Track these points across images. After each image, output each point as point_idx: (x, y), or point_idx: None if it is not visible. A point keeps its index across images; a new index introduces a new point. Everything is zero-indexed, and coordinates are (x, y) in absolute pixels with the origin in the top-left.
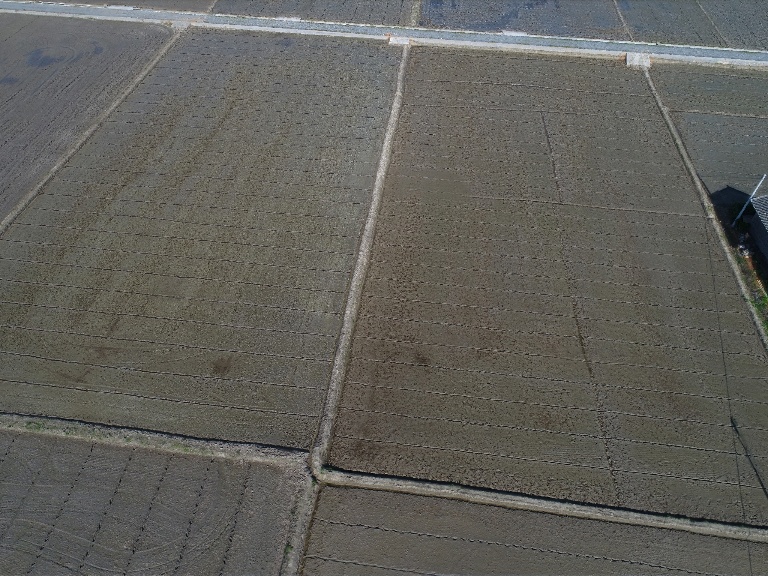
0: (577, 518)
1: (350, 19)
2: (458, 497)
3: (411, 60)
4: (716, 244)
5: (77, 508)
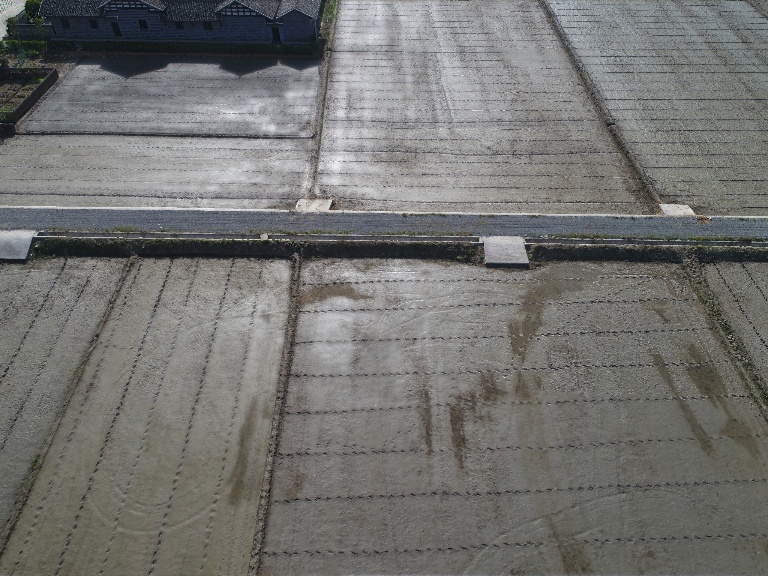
0: None
1: None
2: None
3: (636, 184)
4: None
5: None
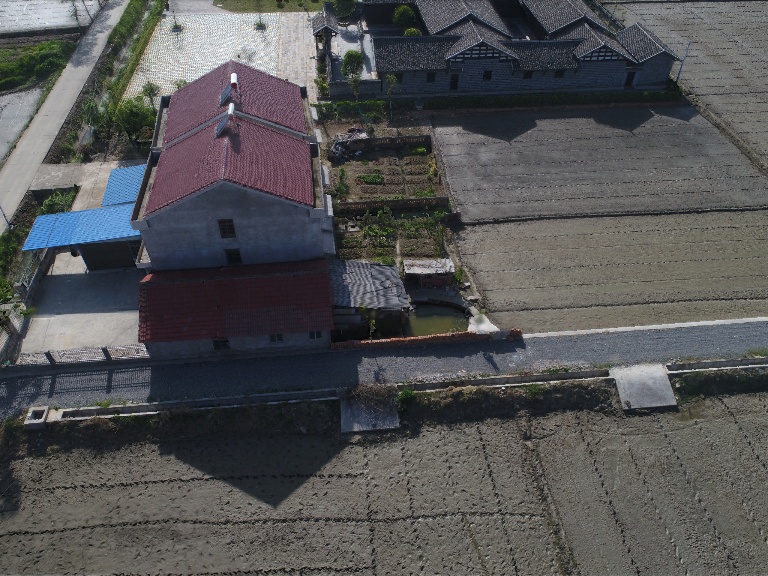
0: None
1: None
2: None
3: None
4: (680, 80)
5: None
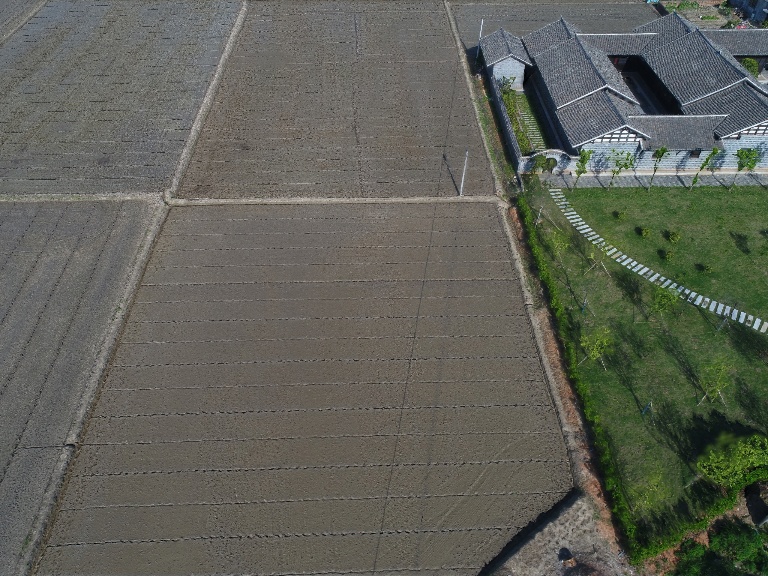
0: (334, 204)
1: None
2: (260, 203)
3: None
4: (461, 75)
5: (7, 230)
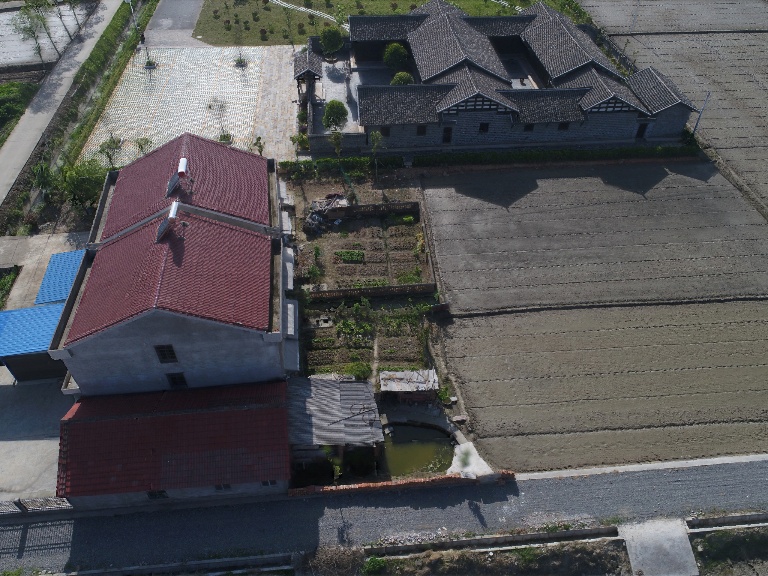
0: None
1: None
2: None
3: None
4: (697, 129)
5: None
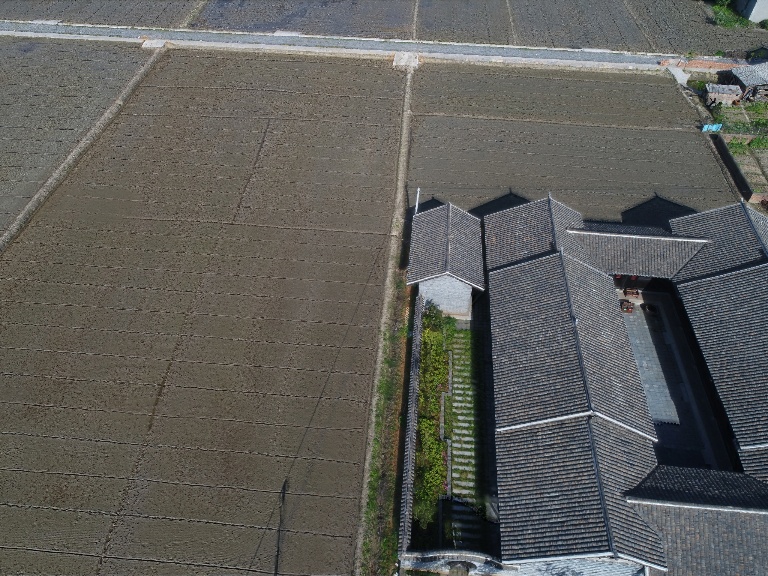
0: None
1: (117, 21)
2: None
3: (158, 64)
4: (383, 266)
5: None
